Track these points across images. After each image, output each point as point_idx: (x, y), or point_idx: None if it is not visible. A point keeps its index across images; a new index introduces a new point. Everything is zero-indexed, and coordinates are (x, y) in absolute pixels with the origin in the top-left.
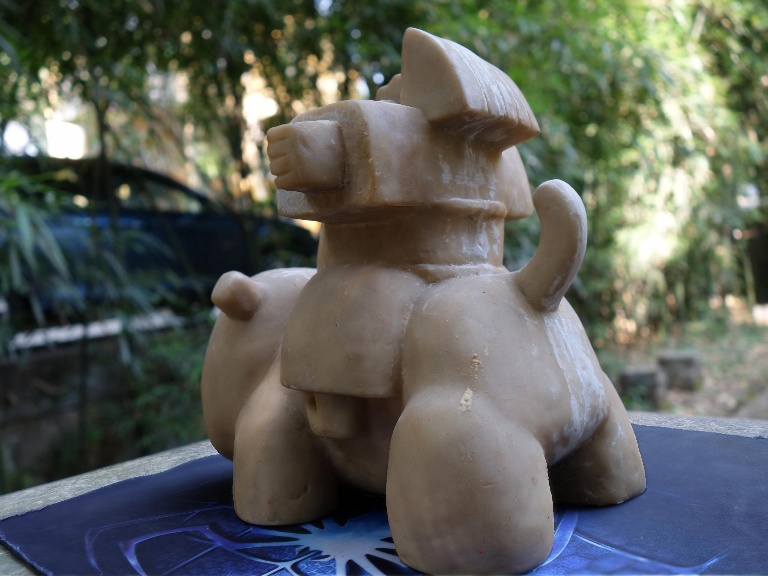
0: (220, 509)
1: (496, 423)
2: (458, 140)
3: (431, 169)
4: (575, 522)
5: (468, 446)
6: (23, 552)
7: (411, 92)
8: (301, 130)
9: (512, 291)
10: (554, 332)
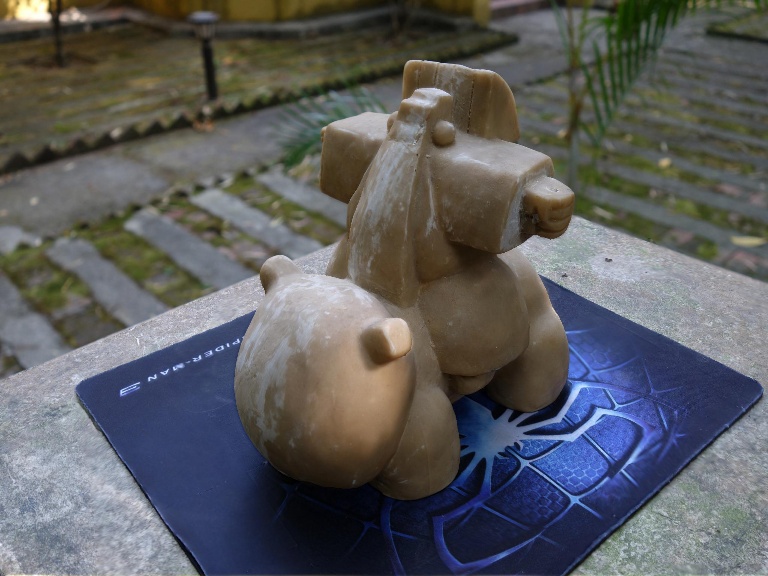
0: (393, 515)
1: None
2: None
3: None
4: None
5: None
6: None
7: (495, 126)
8: None
9: None
10: None
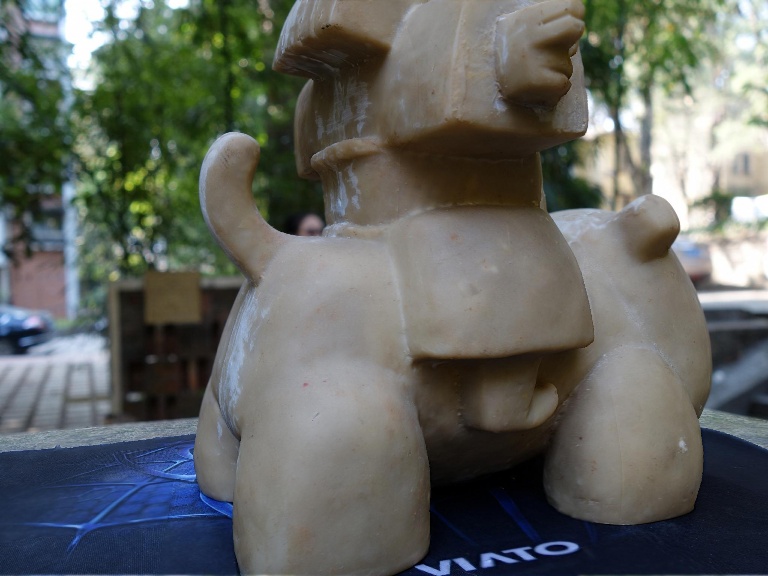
0: None
1: None
2: (330, 81)
3: None
4: None
5: None
6: None
7: None
8: None
9: None
10: None
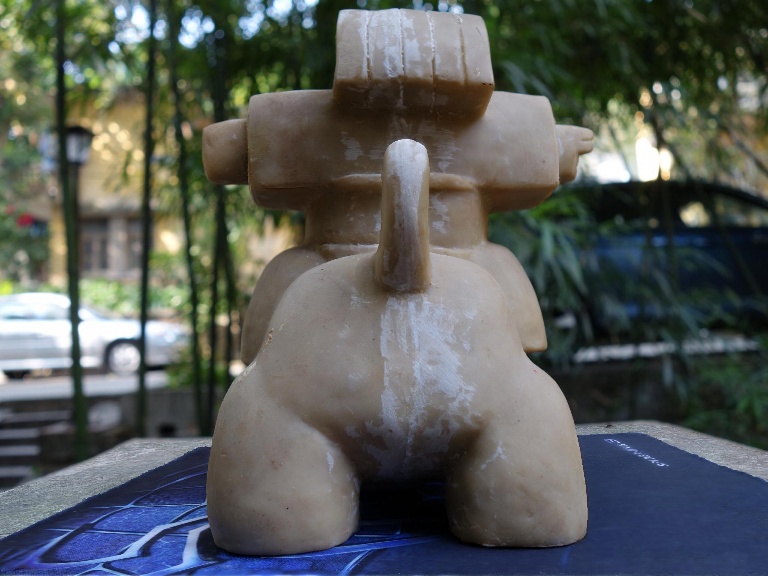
0: None
1: (255, 397)
2: (380, 113)
3: (327, 148)
4: (403, 544)
5: (225, 414)
6: (172, 461)
7: None
8: (208, 132)
9: (358, 268)
10: (396, 316)
